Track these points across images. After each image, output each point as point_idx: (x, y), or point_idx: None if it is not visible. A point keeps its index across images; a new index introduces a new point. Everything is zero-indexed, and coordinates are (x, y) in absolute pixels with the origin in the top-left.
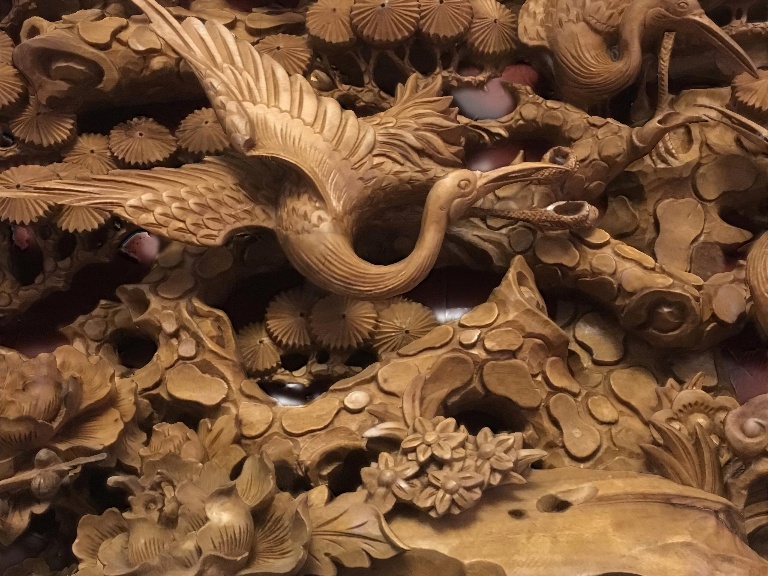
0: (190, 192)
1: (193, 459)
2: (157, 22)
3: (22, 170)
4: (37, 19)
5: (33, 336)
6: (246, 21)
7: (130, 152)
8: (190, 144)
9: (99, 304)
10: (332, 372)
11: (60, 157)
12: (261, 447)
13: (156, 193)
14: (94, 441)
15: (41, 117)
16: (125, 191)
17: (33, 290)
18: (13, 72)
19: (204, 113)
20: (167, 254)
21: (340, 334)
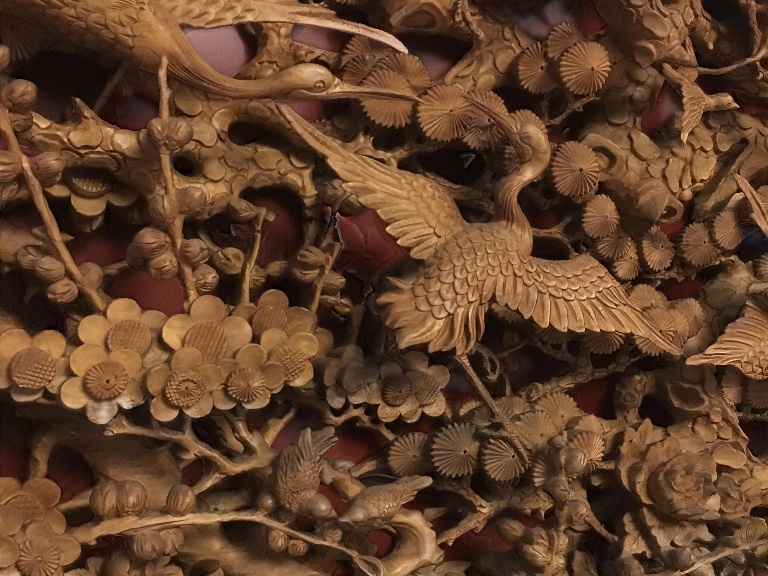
0: (764, 346)
1: (763, 519)
2: (757, 213)
3: (656, 314)
4: (613, 145)
5: (588, 397)
6: (718, 144)
7: (657, 262)
8: (693, 258)
9: (636, 379)
10: (745, 418)
11: (611, 261)
12: (765, 496)
13: (753, 350)
14: (706, 507)
15: (621, 241)
16: (741, 351)
17: (605, 373)
18: (614, 206)
19: (697, 230)
20: (687, 350)
21: (764, 401)
